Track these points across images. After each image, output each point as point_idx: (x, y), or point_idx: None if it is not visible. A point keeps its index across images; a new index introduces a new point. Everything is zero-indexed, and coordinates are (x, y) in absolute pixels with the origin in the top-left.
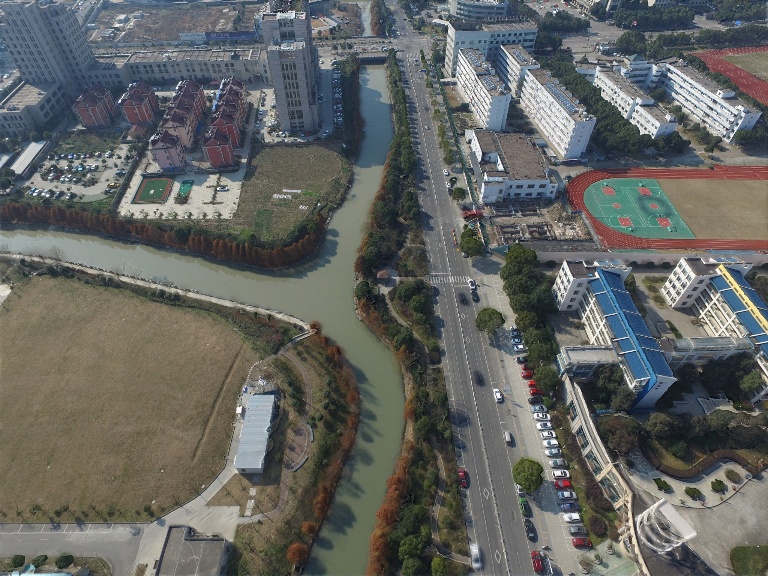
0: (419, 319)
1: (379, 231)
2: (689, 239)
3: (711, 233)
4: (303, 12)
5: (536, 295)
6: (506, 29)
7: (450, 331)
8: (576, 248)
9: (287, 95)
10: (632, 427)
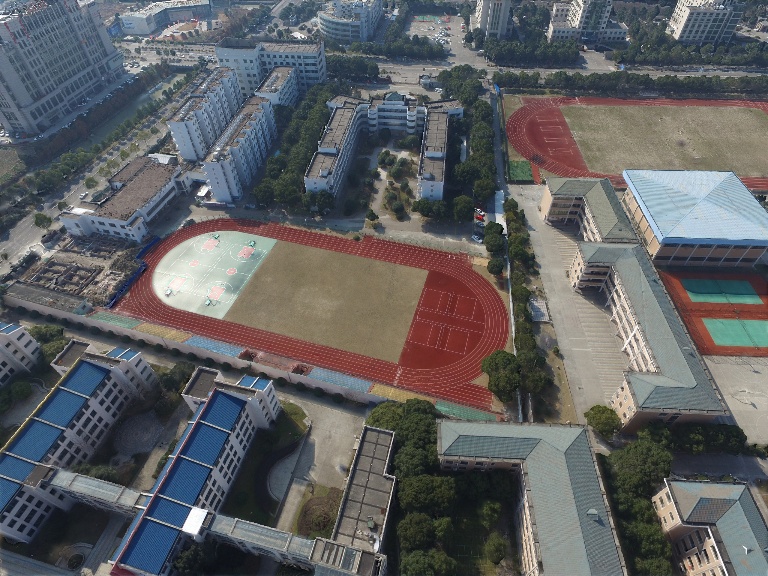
0: None
1: None
2: (213, 318)
3: (247, 316)
4: (16, 16)
5: None
6: (285, 50)
7: None
8: (54, 302)
9: None
10: None
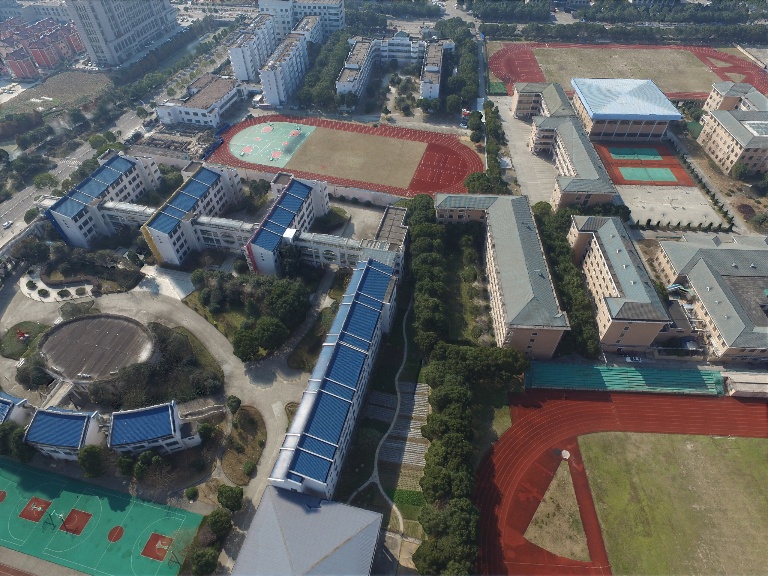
0: (8, 175)
1: (64, 128)
2: (276, 167)
3: (300, 166)
4: None
5: (78, 169)
6: (313, 2)
7: (31, 189)
8: (165, 154)
9: (88, 32)
10: (32, 245)
